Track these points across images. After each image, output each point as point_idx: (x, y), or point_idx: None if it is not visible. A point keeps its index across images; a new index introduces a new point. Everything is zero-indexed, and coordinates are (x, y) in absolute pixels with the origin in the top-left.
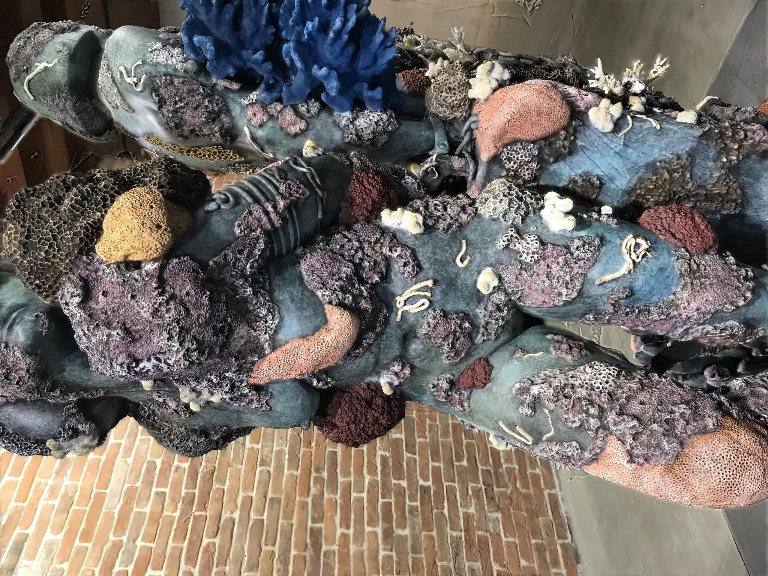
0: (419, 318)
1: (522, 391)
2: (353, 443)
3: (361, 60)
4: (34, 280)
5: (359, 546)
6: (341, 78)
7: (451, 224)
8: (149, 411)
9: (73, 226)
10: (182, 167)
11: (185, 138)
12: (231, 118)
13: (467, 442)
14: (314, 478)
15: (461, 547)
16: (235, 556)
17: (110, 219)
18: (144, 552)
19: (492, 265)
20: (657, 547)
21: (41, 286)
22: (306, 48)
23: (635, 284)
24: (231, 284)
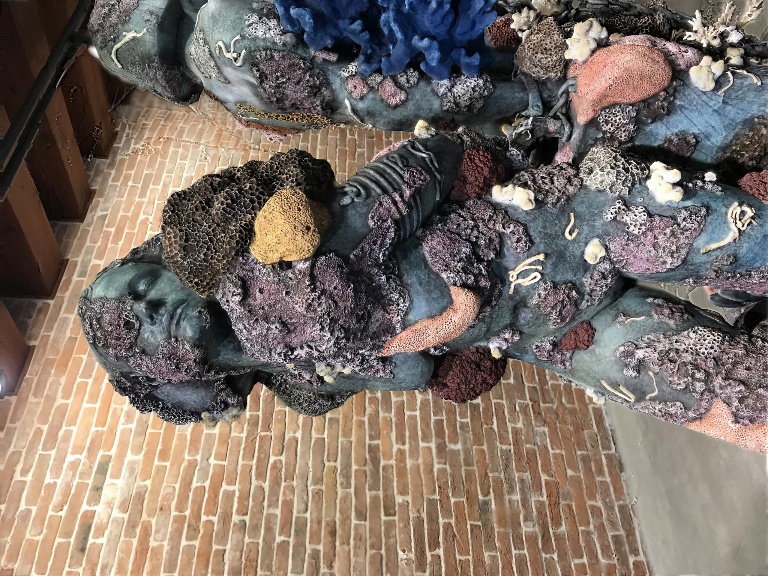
0: (530, 290)
1: (626, 354)
2: (461, 400)
3: (459, 26)
4: (193, 279)
5: (415, 460)
6: (440, 46)
7: (559, 197)
8: (282, 380)
9: (226, 228)
10: (312, 160)
11: (284, 110)
12: (332, 91)
13: (513, 361)
14: (369, 399)
15: (511, 459)
16: (301, 471)
17: (263, 223)
18: (218, 469)
19: (599, 236)
20: (703, 459)
21: (199, 283)
22: (405, 17)
23: (739, 251)
24: (367, 273)
